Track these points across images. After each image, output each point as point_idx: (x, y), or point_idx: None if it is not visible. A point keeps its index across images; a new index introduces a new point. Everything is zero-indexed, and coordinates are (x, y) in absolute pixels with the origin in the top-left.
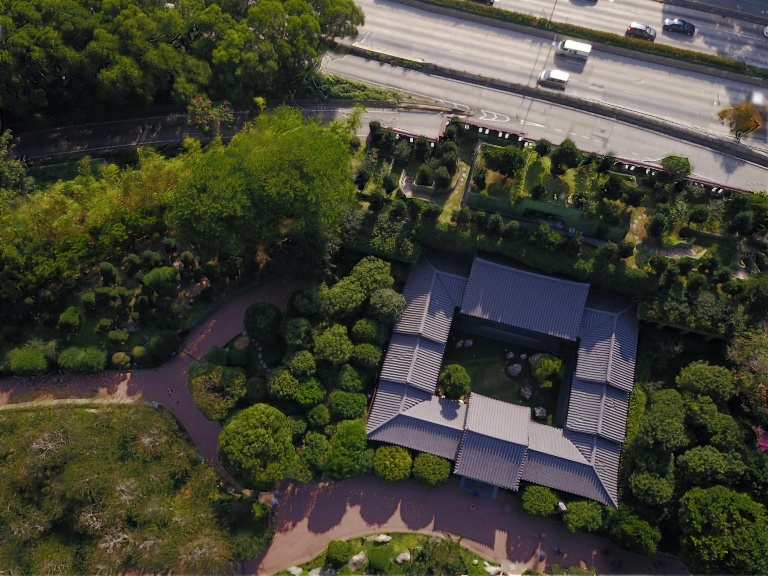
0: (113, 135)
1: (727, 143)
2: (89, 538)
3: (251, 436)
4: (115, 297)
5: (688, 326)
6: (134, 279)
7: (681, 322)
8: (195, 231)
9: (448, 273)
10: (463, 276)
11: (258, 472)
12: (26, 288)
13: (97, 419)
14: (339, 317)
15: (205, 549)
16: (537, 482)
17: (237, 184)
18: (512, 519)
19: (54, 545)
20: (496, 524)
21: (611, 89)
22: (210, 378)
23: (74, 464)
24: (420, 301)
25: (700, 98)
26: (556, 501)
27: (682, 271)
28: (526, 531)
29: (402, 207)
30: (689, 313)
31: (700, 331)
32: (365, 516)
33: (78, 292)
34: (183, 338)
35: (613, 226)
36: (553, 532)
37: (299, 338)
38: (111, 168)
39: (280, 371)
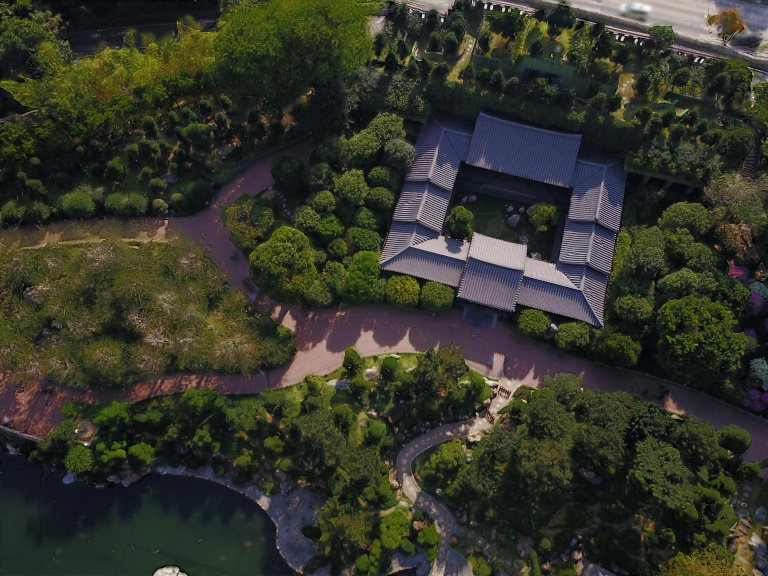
0: (148, 37)
1: (715, 46)
2: (134, 343)
3: (279, 247)
4: (156, 151)
5: (670, 173)
6: (172, 138)
7: (663, 169)
8: (231, 74)
9: (455, 130)
10: (468, 133)
11: (284, 282)
12: (78, 138)
13: (141, 246)
14: (356, 164)
15: (237, 343)
16: (532, 306)
17: (270, 28)
18: (509, 345)
19: (104, 343)
20: (495, 348)
21: (609, 3)
22: (242, 208)
23: (123, 273)
24: (429, 154)
25: (691, 12)
26: (548, 323)
27: (665, 123)
28: (521, 354)
29: (414, 68)
30: (670, 160)
31: (681, 179)
32: (377, 340)
33: (122, 148)
34: (215, 191)
35: (603, 83)
36: (546, 356)
37: (321, 179)
38: (151, 46)
39: (304, 207)
